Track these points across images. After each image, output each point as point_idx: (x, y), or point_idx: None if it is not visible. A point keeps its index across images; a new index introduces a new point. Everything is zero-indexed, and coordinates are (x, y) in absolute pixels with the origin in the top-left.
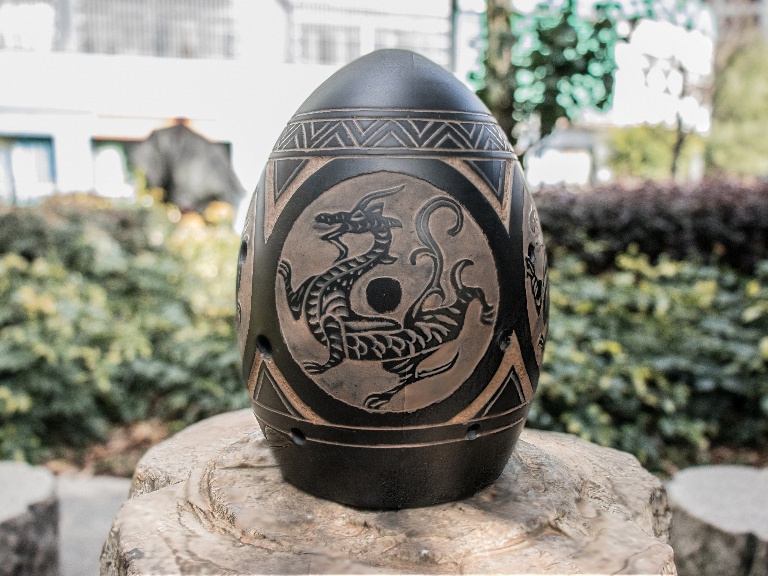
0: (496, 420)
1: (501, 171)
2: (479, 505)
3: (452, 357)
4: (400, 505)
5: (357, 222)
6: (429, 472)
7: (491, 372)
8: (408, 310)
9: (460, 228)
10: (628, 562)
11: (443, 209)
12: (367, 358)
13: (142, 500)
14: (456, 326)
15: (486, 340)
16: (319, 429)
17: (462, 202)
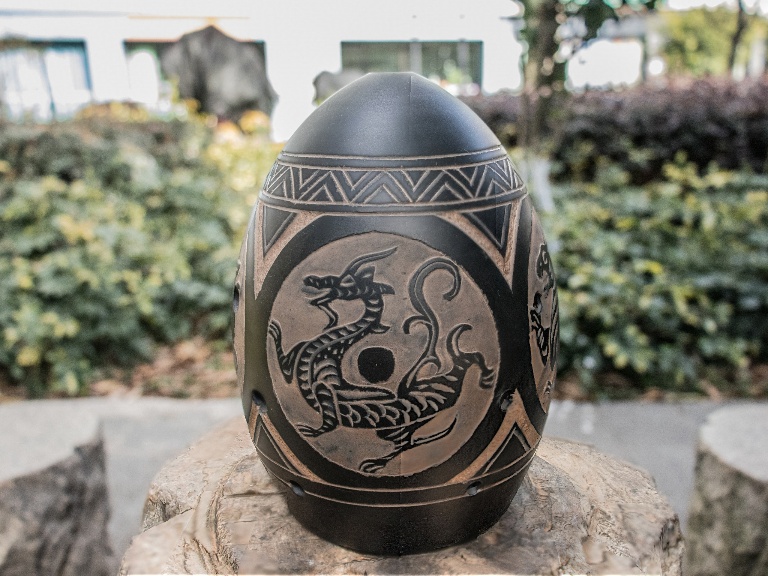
0: (498, 474)
1: (505, 218)
2: (482, 551)
3: (449, 423)
4: (401, 551)
5: (347, 288)
6: (429, 524)
7: (491, 433)
8: (402, 380)
9: (457, 291)
10: None
11: (439, 272)
12: (361, 426)
13: (150, 536)
14: (453, 393)
15: (486, 403)
16: (316, 486)
17: (460, 262)
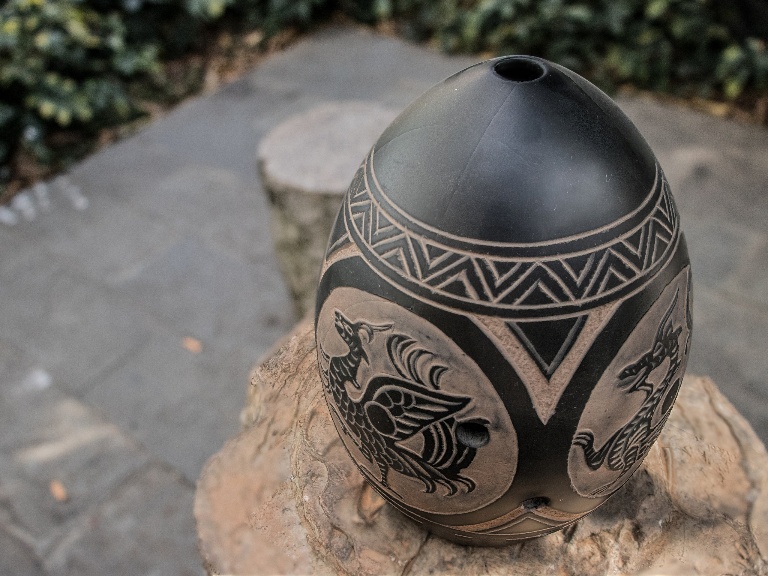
0: None
1: None
2: None
3: None
4: None
5: None
6: None
7: None
8: None
9: None
10: (722, 416)
11: None
12: None
13: None
14: None
15: None
16: None
17: None
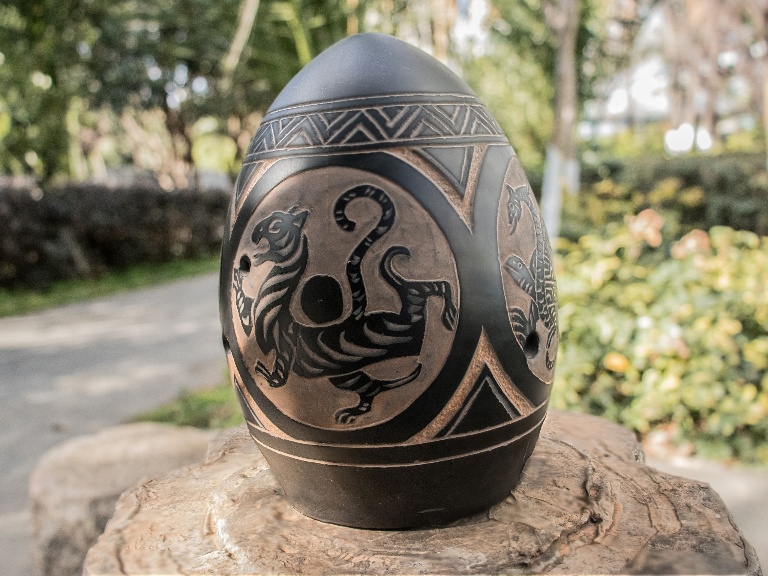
0: None
1: (250, 175)
2: (271, 506)
3: None
4: None
5: None
6: None
7: None
8: None
9: None
10: None
11: None
12: None
13: None
14: None
15: None
16: None
17: None
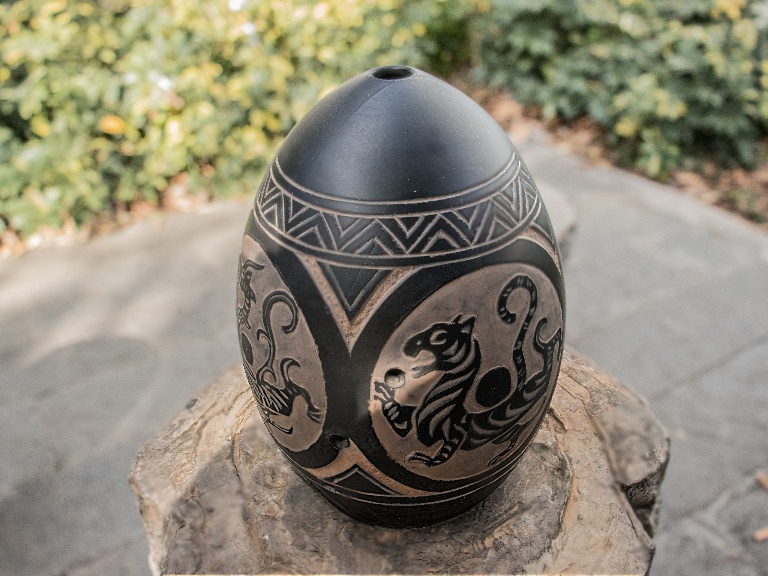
0: None
1: (370, 282)
2: (359, 537)
3: (289, 427)
4: None
5: None
6: None
7: (328, 458)
8: (257, 372)
9: (293, 329)
10: None
11: (283, 304)
12: None
13: None
14: (287, 407)
15: (316, 432)
16: None
17: (301, 305)
